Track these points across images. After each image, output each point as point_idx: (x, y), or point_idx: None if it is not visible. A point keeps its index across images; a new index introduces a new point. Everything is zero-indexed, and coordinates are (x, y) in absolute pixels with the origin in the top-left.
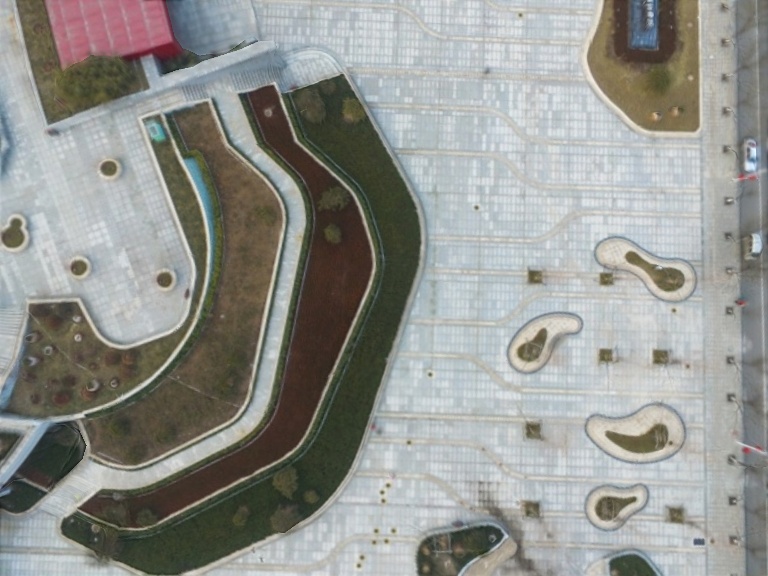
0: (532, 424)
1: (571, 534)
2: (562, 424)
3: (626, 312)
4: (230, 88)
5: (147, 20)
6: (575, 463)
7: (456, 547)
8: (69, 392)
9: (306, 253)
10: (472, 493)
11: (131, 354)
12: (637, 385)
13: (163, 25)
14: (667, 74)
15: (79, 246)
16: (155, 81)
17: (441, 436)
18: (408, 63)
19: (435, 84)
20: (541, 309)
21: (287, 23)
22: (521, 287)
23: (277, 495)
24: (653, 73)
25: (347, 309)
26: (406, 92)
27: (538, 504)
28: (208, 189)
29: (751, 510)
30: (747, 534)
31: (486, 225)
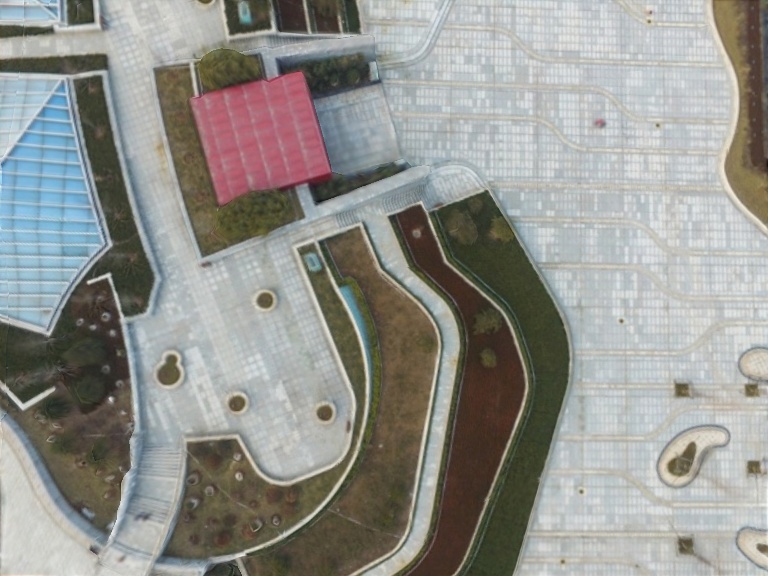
0: (684, 539)
1: None
2: (713, 538)
3: None
4: (380, 211)
5: (304, 150)
6: None
7: None
8: (230, 531)
9: (460, 377)
10: None
11: (294, 491)
12: None
13: (321, 155)
14: None
15: (235, 380)
16: (310, 210)
17: (594, 554)
18: (549, 176)
19: (576, 197)
20: (689, 422)
21: (427, 137)
22: (668, 400)
23: None
24: None
25: (502, 432)
26: (548, 205)
27: None
28: (364, 317)
29: None
30: None
31: (631, 338)
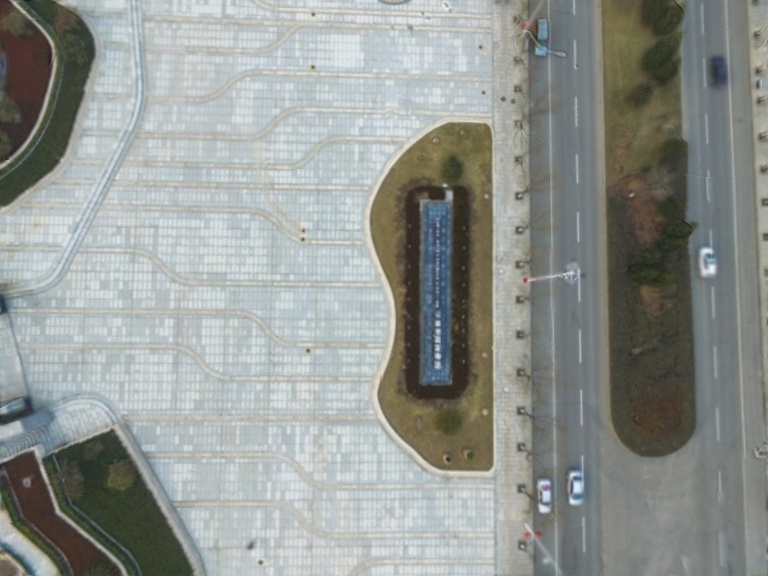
0: None
1: None
2: None
3: None
4: None
5: None
6: None
7: None
8: None
9: None
10: None
11: None
12: None
13: None
14: (460, 410)
15: None
16: None
17: None
18: (188, 407)
19: (217, 429)
20: None
21: (56, 369)
22: None
23: None
24: (445, 411)
25: None
26: (186, 439)
27: None
28: None
29: None
30: None
31: None
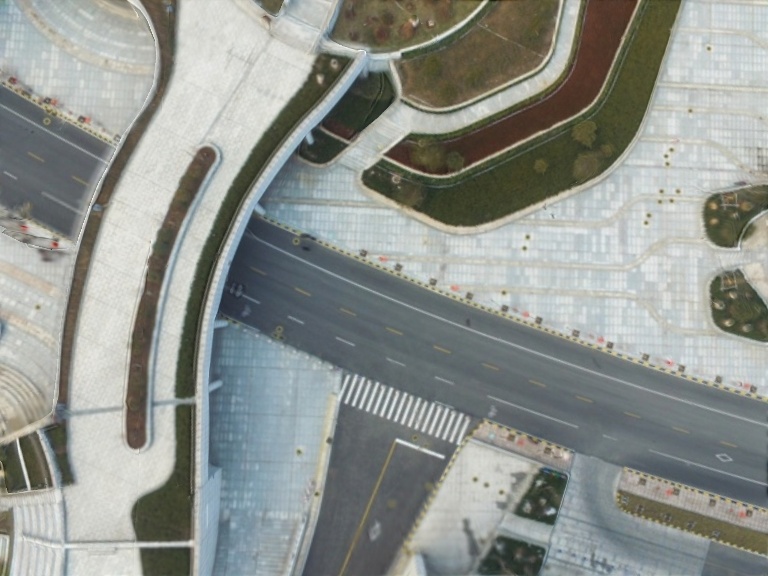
0: None
1: None
2: None
3: None
4: None
5: None
6: None
7: (743, 201)
8: (387, 30)
9: None
10: (751, 158)
11: None
12: None
13: None
14: None
15: None
16: None
17: (720, 105)
18: None
19: None
20: None
21: None
22: None
23: (576, 145)
24: None
25: None
26: None
27: None
28: None
29: None
30: None
31: None
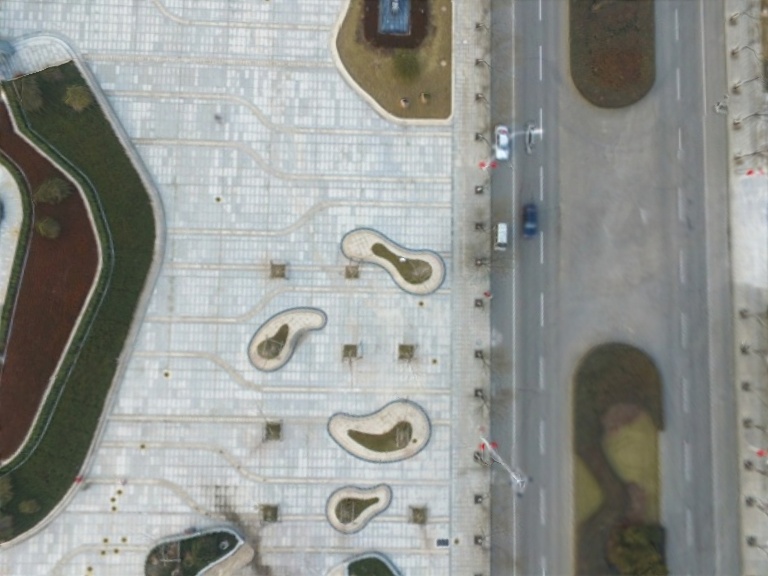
0: (272, 424)
1: (311, 538)
2: (304, 424)
3: (372, 306)
4: None
5: None
6: (316, 464)
7: (185, 555)
8: None
9: (24, 249)
10: (208, 498)
11: None
12: (382, 382)
13: None
14: (418, 60)
15: None
16: None
17: (177, 439)
18: (147, 49)
19: (176, 71)
20: (284, 304)
21: (17, 7)
22: (264, 282)
23: None
24: (403, 59)
25: (69, 307)
26: (145, 79)
27: (276, 508)
28: None
29: (497, 508)
30: (492, 533)
31: (228, 218)
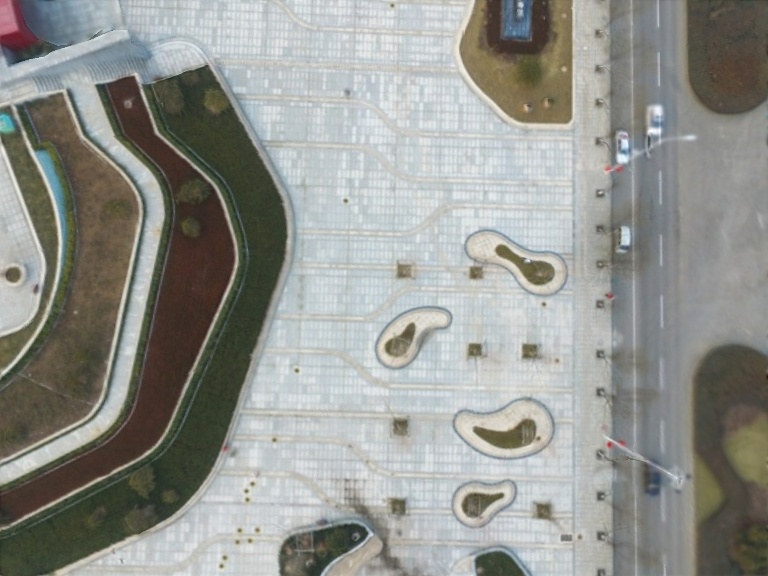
0: (399, 420)
1: (438, 531)
2: (430, 420)
3: (496, 306)
4: (87, 79)
5: None
6: (443, 459)
7: (318, 546)
8: None
9: (165, 247)
10: (338, 491)
11: None
12: (506, 380)
13: (8, 14)
14: (540, 65)
15: None
16: (3, 71)
17: (307, 433)
18: (277, 54)
19: (304, 75)
20: (410, 303)
21: (153, 13)
22: (390, 281)
23: (134, 495)
24: (525, 64)
25: (208, 304)
26: (275, 83)
27: (404, 501)
28: (61, 182)
29: (619, 505)
30: (614, 529)
31: (355, 218)
